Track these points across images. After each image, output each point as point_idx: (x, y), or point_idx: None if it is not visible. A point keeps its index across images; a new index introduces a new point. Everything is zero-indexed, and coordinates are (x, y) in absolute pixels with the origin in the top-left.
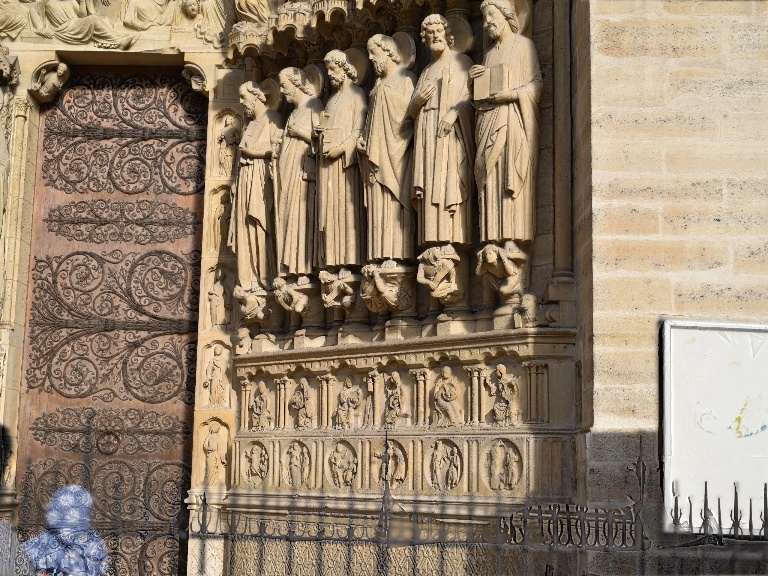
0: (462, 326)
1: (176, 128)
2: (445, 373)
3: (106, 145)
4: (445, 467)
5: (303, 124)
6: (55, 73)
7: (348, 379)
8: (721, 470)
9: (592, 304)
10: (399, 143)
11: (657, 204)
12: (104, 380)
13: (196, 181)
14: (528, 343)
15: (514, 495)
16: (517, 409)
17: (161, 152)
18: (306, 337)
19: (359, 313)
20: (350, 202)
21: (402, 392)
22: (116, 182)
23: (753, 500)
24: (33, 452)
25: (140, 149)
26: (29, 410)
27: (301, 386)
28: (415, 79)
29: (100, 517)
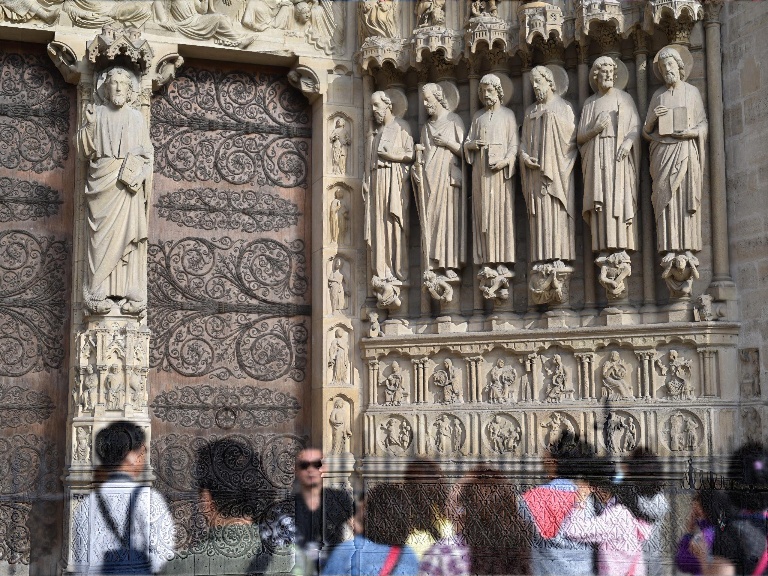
0: (630, 318)
1: (276, 124)
2: (615, 356)
3: (211, 136)
4: (619, 434)
5: (448, 135)
6: (172, 65)
7: (501, 360)
8: None
9: None
10: (566, 162)
11: None
12: (219, 359)
13: (296, 175)
14: (706, 334)
15: (696, 455)
16: (691, 386)
17: (263, 146)
18: (452, 323)
19: (509, 304)
20: (510, 208)
21: (566, 372)
22: (222, 172)
23: None
24: (155, 428)
25: (243, 142)
26: (149, 388)
27: (446, 366)
28: (573, 107)
29: (222, 488)
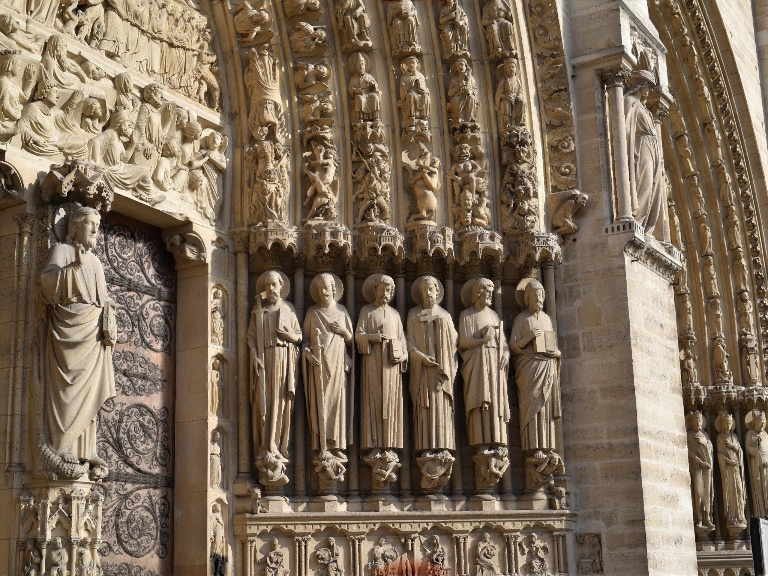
0: None
1: (149, 285)
2: (488, 538)
3: None
4: None
5: (342, 324)
6: None
7: (384, 539)
8: None
9: (643, 500)
10: (453, 363)
11: None
12: (102, 533)
13: (163, 340)
14: (563, 520)
15: None
16: (548, 564)
17: (140, 306)
18: (338, 502)
19: None
20: None
21: (445, 551)
22: None
23: None
24: None
25: (125, 299)
26: None
27: (332, 544)
28: None
29: None
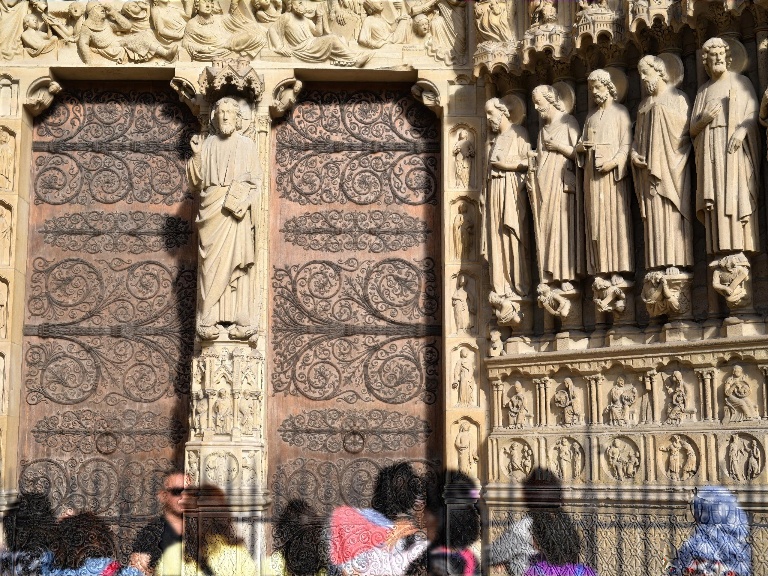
0: (753, 328)
1: (403, 141)
2: (737, 372)
3: (336, 158)
4: (743, 459)
5: (561, 139)
6: (291, 90)
7: (621, 378)
8: None
9: None
10: (678, 158)
11: None
12: (347, 383)
13: (425, 192)
14: None
15: None
16: None
17: (390, 164)
18: (570, 339)
19: (629, 316)
20: (622, 213)
21: (686, 390)
22: (348, 193)
23: None
24: (282, 453)
25: (369, 162)
26: (276, 413)
27: (566, 385)
28: (687, 97)
29: (350, 513)
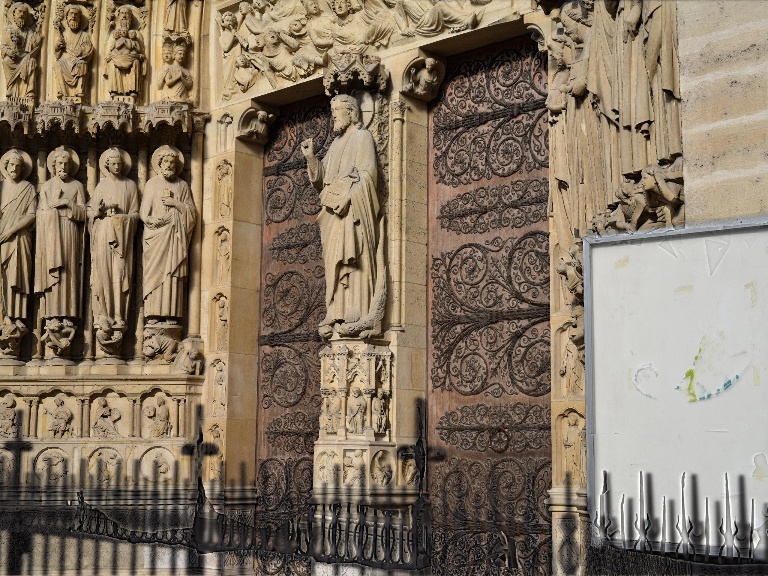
0: None
1: (541, 97)
2: None
3: (483, 130)
4: None
5: None
6: (425, 69)
7: None
8: (666, 453)
9: None
10: None
11: (765, 66)
12: (493, 375)
13: None
14: None
15: None
16: None
17: (530, 126)
18: None
19: None
20: None
21: None
22: (493, 167)
23: (710, 500)
24: None
25: (511, 127)
26: (435, 410)
27: None
28: None
29: None
